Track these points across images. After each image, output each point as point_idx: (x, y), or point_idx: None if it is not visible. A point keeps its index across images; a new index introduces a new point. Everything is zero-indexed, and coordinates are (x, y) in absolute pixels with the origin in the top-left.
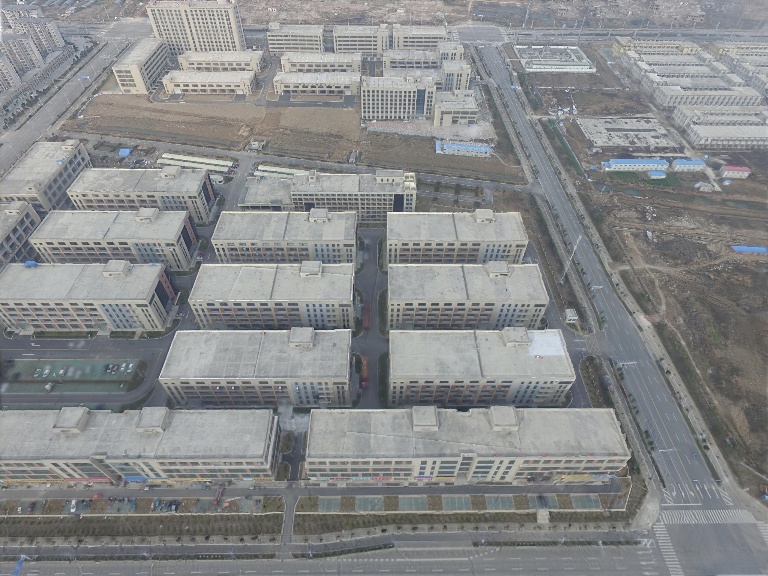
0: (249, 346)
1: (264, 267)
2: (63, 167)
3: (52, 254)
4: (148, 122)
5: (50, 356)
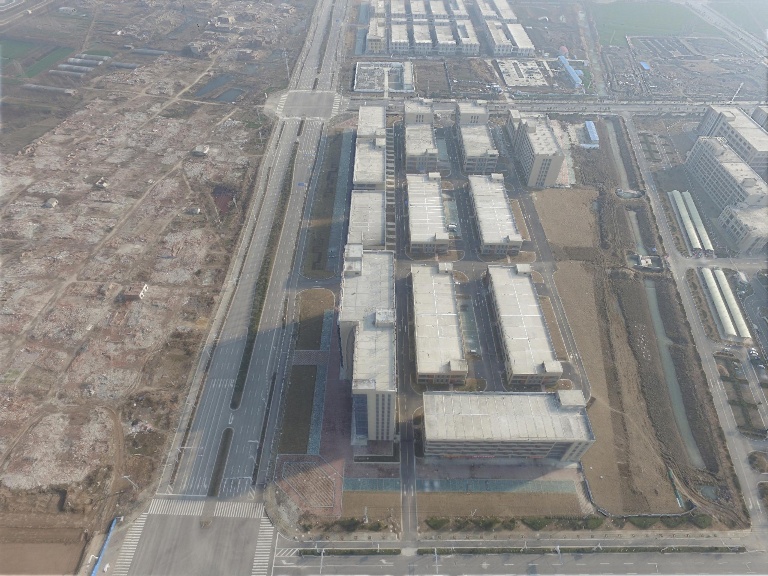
0: None
1: None
2: None
3: None
4: (653, 387)
5: None
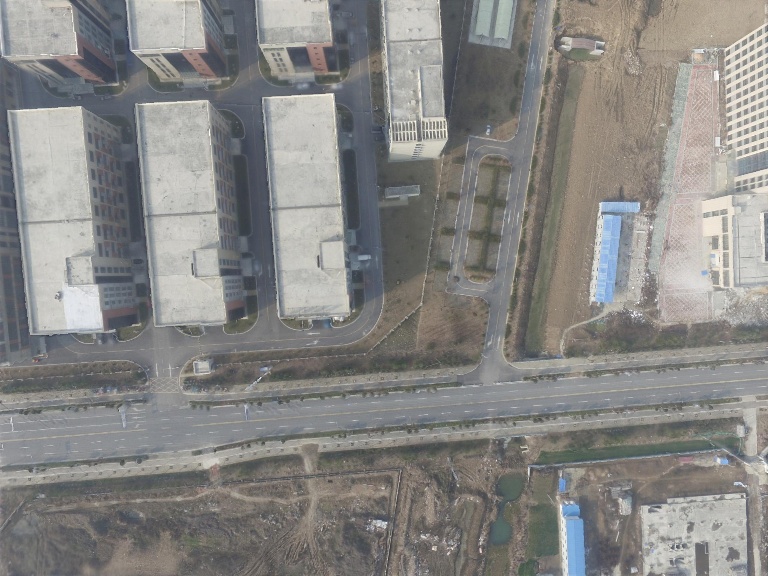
0: None
1: None
2: None
3: None
4: None
5: None
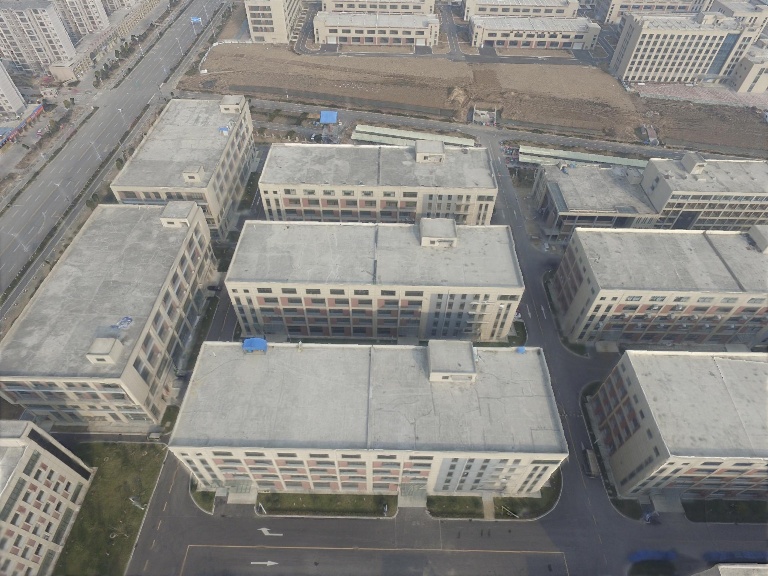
0: None
1: (764, 359)
2: (231, 140)
3: (258, 309)
4: (305, 80)
5: (316, 570)
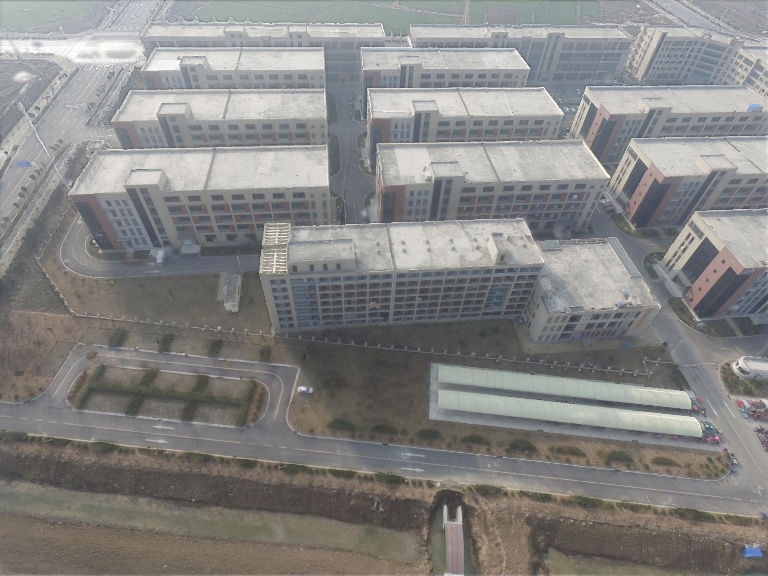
0: (456, 64)
1: None
2: None
3: None
4: None
5: None
